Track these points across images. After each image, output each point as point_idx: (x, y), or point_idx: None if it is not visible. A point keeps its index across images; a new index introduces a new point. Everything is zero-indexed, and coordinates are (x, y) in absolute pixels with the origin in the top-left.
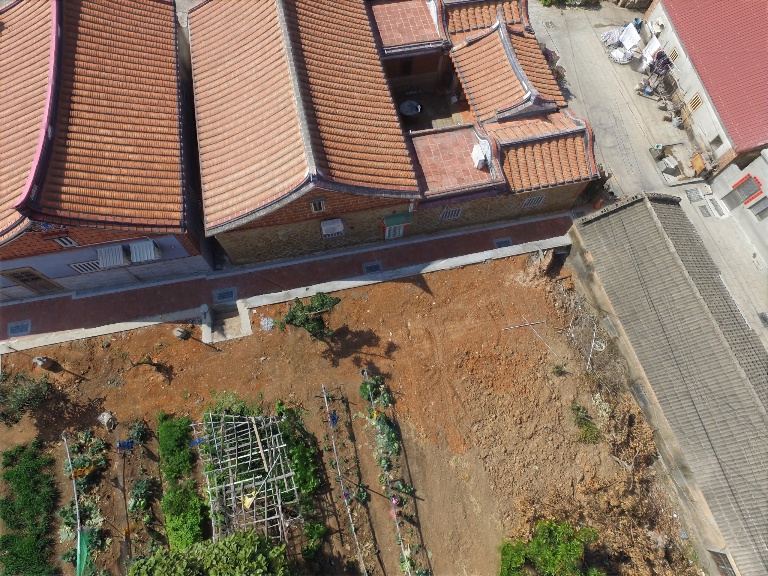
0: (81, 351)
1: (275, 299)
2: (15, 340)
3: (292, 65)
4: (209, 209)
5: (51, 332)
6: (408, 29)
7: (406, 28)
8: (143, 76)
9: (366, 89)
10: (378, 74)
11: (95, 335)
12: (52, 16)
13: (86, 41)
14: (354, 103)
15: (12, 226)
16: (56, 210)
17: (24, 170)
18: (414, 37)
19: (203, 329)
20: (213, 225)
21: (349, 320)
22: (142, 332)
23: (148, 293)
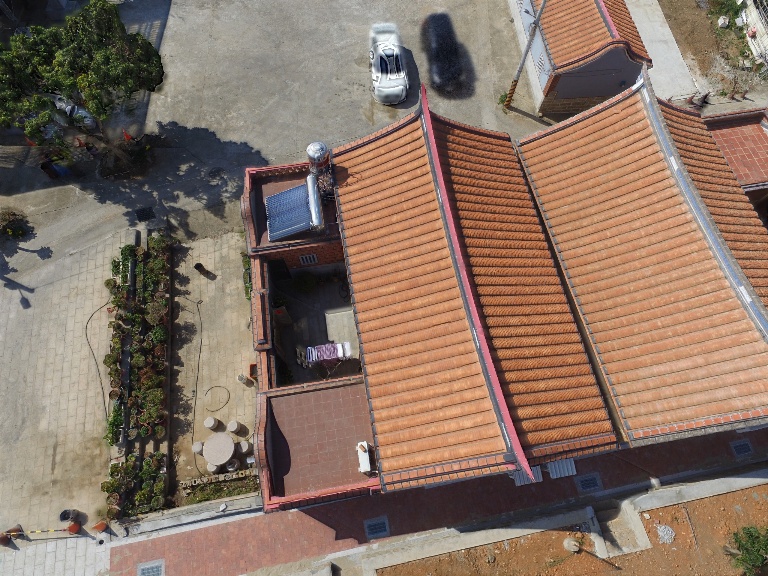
0: (465, 567)
1: (667, 500)
2: (376, 543)
3: (724, 243)
4: (628, 411)
5: (412, 533)
6: (753, 162)
7: (750, 161)
8: (518, 238)
9: (764, 253)
10: (763, 230)
11: (475, 545)
12: (439, 179)
13: (462, 201)
14: (765, 276)
15: (477, 467)
16: (531, 450)
17: (452, 379)
18: (763, 172)
19: (595, 539)
20: (643, 436)
21: (760, 531)
22: (527, 542)
23: (505, 481)
